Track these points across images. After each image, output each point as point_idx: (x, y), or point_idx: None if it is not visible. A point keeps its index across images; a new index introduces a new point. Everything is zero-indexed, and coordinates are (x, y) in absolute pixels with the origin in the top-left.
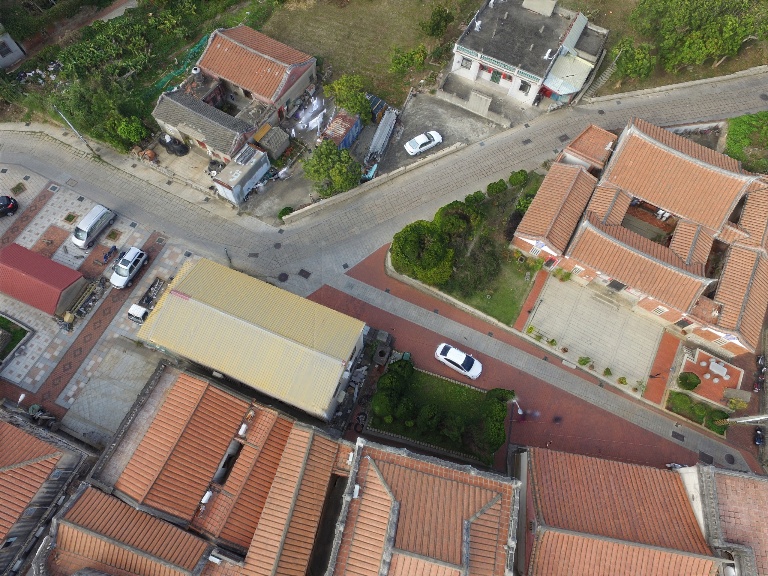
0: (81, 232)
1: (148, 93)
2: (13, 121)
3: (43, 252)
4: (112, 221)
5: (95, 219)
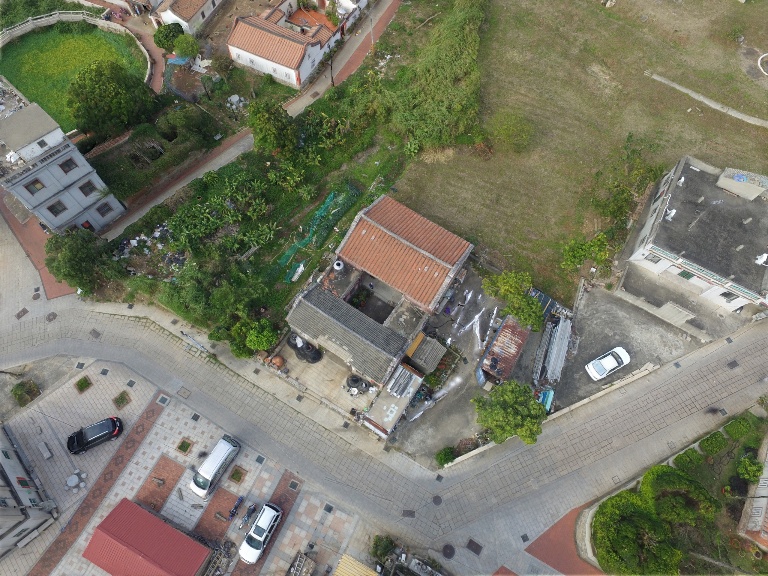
0: (202, 478)
1: (271, 272)
2: (114, 301)
3: (154, 496)
4: (235, 455)
5: (220, 463)
